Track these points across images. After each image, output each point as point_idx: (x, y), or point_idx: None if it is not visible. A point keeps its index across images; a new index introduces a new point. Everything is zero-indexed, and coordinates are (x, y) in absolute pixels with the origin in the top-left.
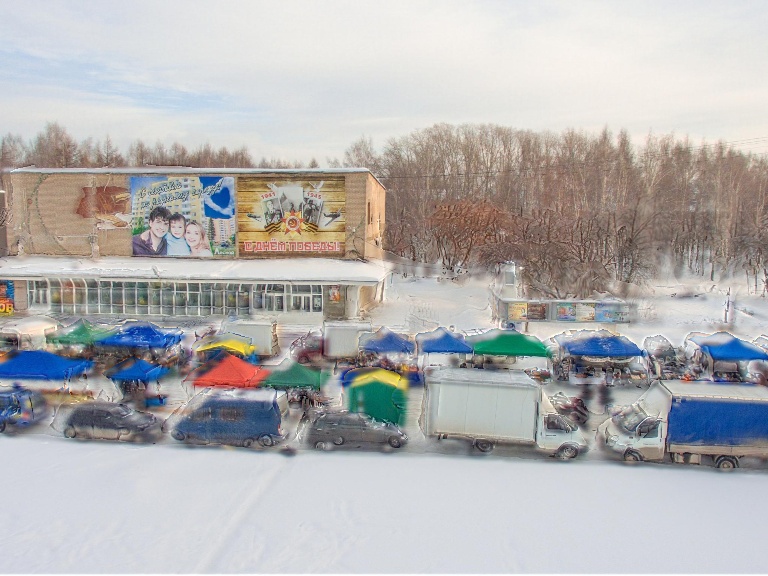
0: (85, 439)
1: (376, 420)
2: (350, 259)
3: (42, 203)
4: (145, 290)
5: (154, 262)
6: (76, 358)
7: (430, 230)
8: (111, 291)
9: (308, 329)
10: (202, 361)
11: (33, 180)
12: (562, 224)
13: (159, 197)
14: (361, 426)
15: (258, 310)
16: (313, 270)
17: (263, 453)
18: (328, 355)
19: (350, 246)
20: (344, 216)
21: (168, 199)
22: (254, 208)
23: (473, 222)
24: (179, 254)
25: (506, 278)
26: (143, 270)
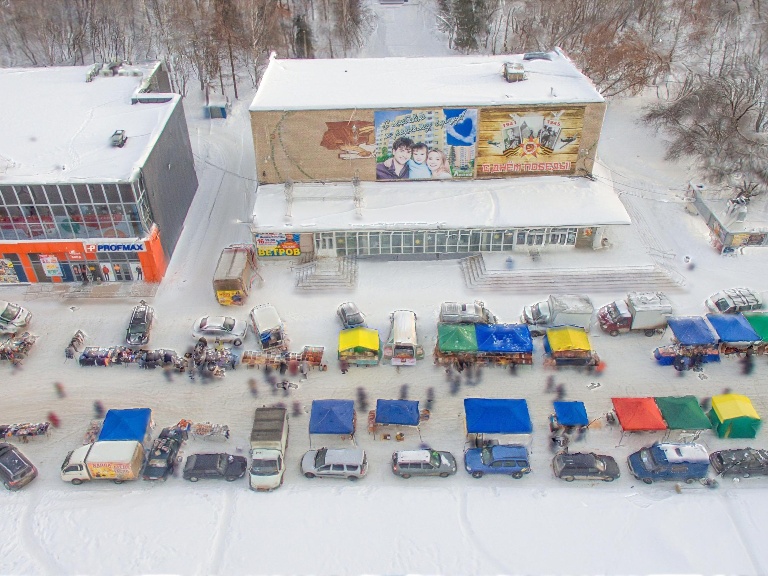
0: (599, 494)
1: (761, 454)
2: (578, 176)
3: (285, 137)
4: (421, 235)
5: (417, 202)
6: (523, 403)
7: (577, 59)
8: (391, 237)
9: (579, 274)
10: (560, 357)
11: (274, 117)
12: (695, 30)
13: (402, 128)
14: (761, 467)
15: (520, 246)
16: (573, 215)
17: (721, 502)
18: (634, 329)
19: (580, 165)
20: (579, 140)
21: (411, 130)
22: (495, 136)
23: (582, 2)
24: (420, 177)
25: (738, 217)
26: (425, 224)
